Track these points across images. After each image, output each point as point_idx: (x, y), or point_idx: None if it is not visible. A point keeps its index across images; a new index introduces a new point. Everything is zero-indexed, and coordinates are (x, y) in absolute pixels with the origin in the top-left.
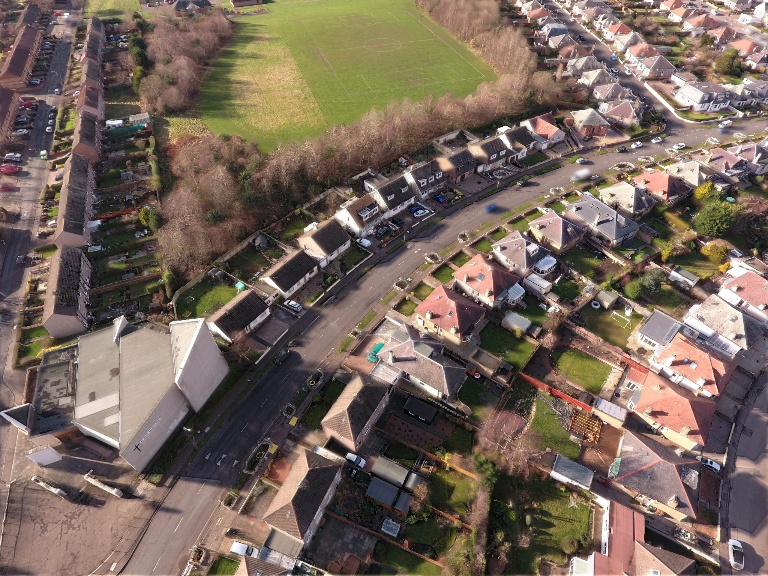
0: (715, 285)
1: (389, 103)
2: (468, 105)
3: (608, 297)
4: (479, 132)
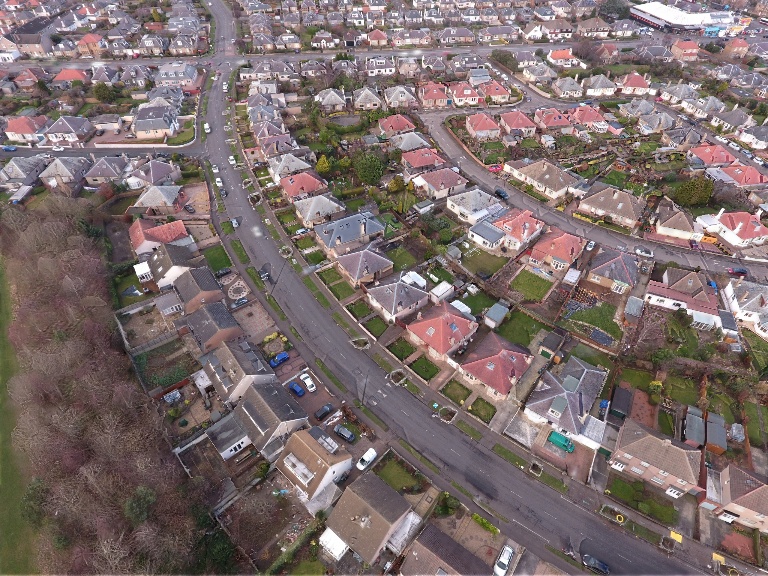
0: (426, 197)
1: (10, 391)
2: (75, 289)
3: (455, 251)
4: (120, 299)
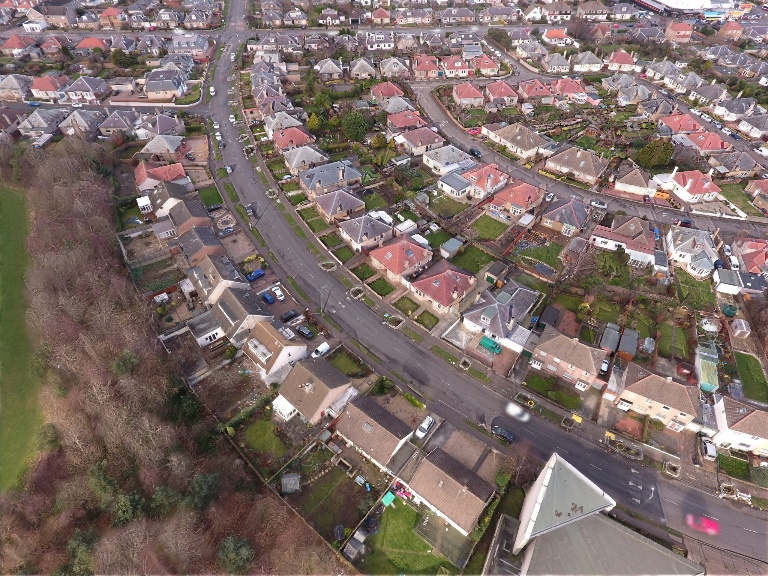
0: None
1: (26, 281)
2: (84, 211)
3: (423, 196)
4: (123, 225)
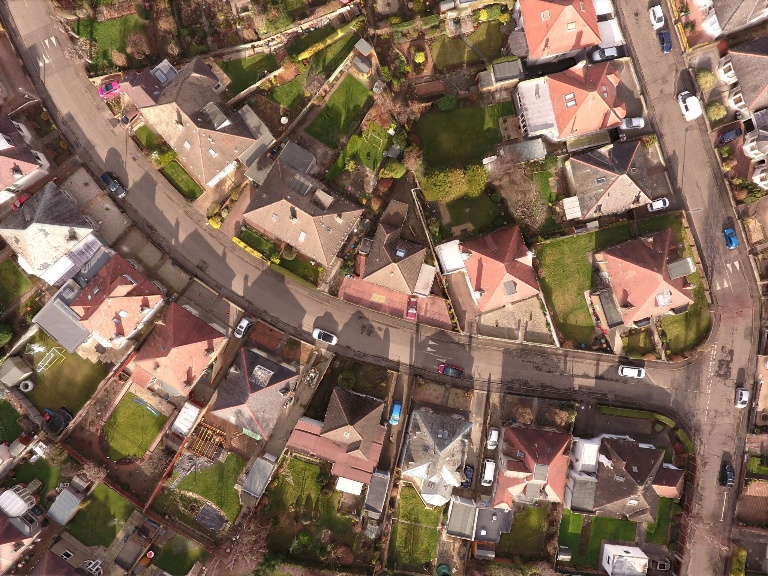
0: None
1: None
2: None
3: (12, 374)
4: None
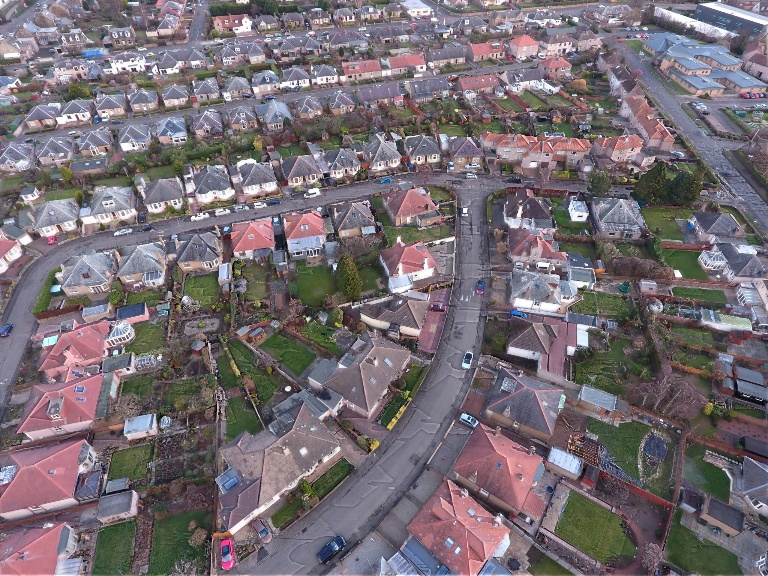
0: None
1: None
2: None
3: None
4: None
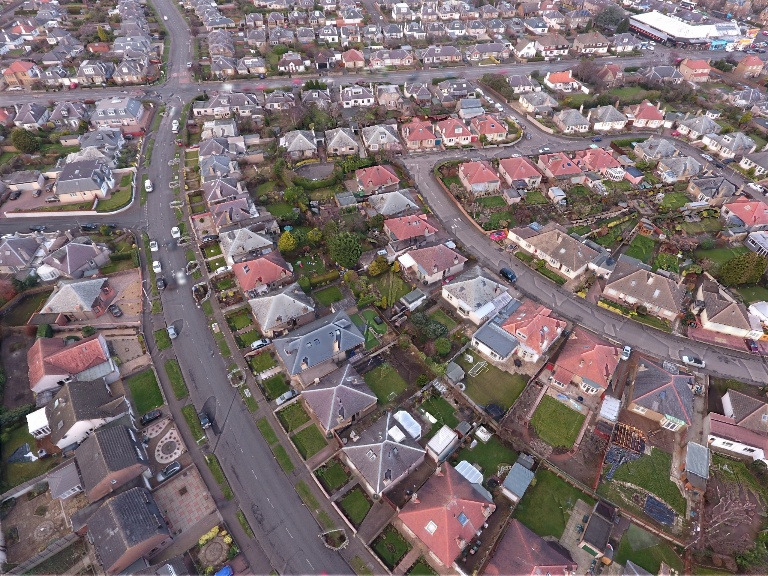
0: (415, 281)
1: None
2: None
3: (457, 371)
4: (5, 469)
